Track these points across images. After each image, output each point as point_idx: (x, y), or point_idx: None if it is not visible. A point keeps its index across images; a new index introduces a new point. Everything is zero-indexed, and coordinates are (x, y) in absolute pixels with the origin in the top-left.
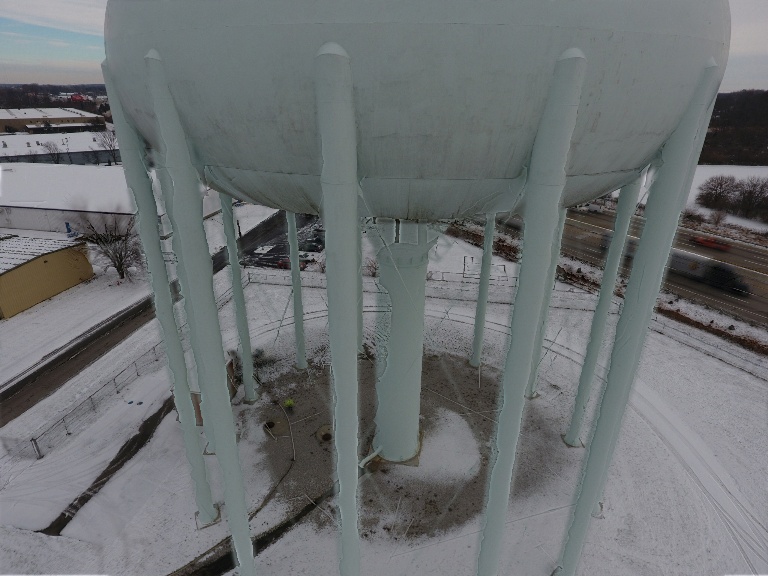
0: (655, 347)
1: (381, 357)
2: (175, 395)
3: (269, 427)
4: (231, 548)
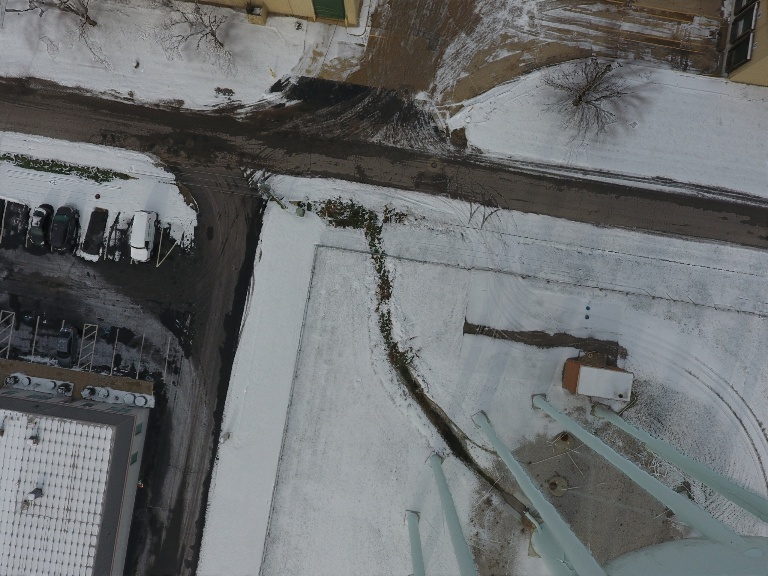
0: None
1: (671, 523)
2: (502, 454)
3: (562, 438)
4: (461, 440)
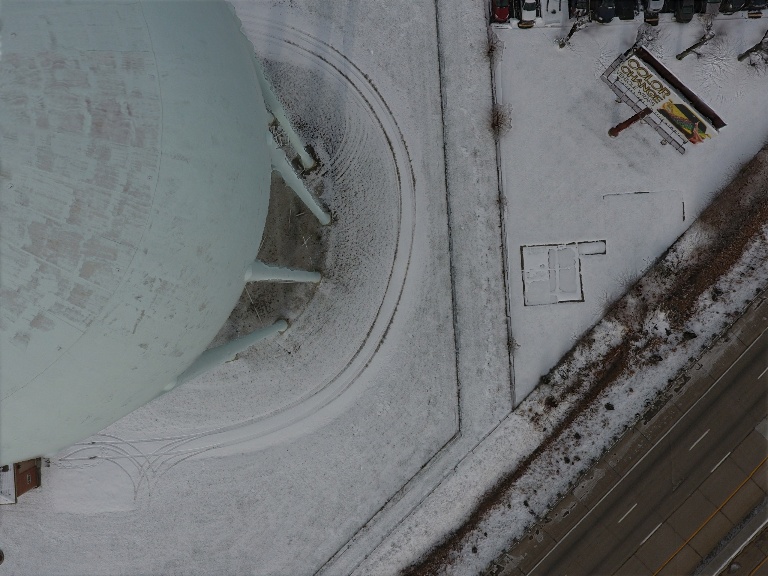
0: (389, 452)
1: None
2: None
3: None
4: None
